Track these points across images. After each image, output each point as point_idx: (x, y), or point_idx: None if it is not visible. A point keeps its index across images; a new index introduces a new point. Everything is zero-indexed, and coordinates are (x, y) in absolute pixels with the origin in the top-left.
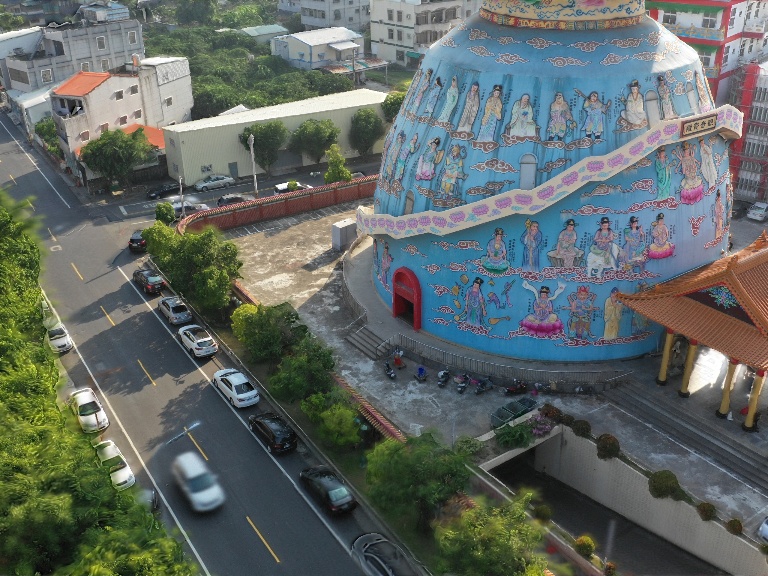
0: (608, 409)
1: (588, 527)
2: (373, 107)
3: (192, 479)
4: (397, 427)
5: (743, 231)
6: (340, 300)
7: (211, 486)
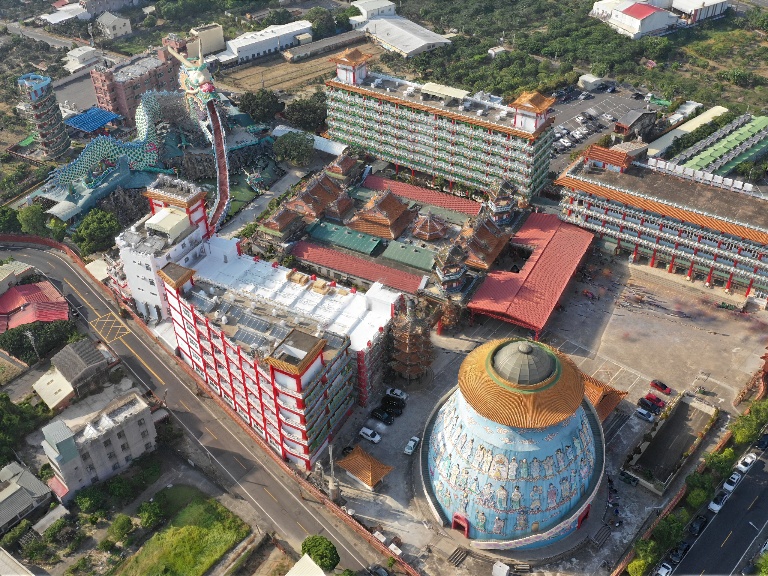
0: (605, 455)
1: (648, 468)
2: (331, 575)
3: (716, 571)
4: (651, 515)
5: (420, 404)
6: (565, 560)
7: (716, 563)
